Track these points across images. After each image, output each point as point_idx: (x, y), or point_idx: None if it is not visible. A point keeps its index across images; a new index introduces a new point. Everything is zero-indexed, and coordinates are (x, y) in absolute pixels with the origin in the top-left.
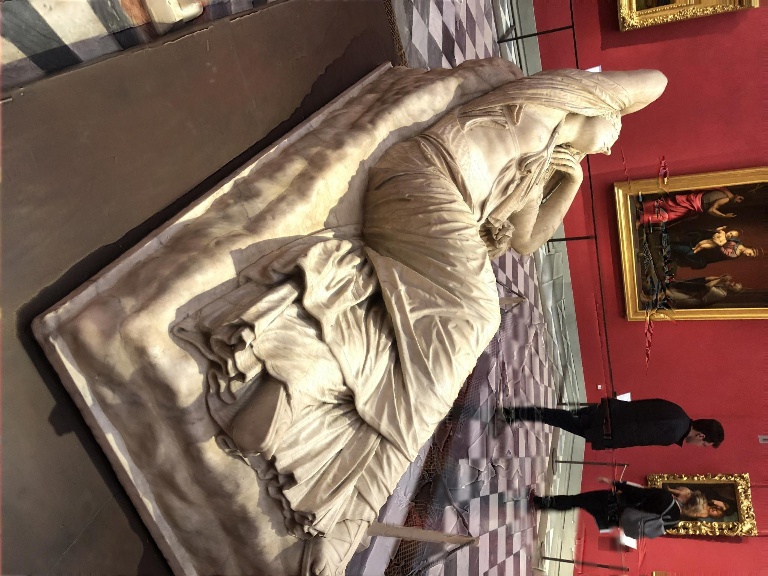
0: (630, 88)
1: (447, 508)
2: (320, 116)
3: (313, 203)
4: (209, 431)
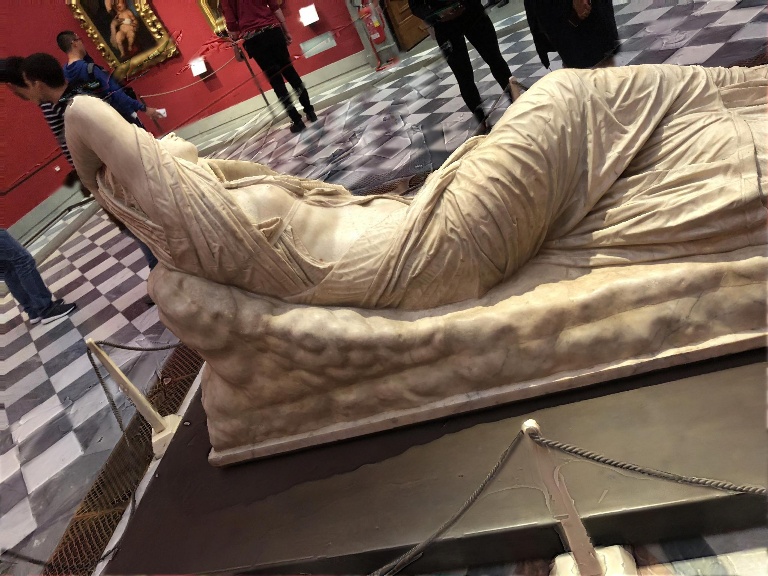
0: (128, 130)
1: (487, 125)
2: (440, 406)
3: None
4: None
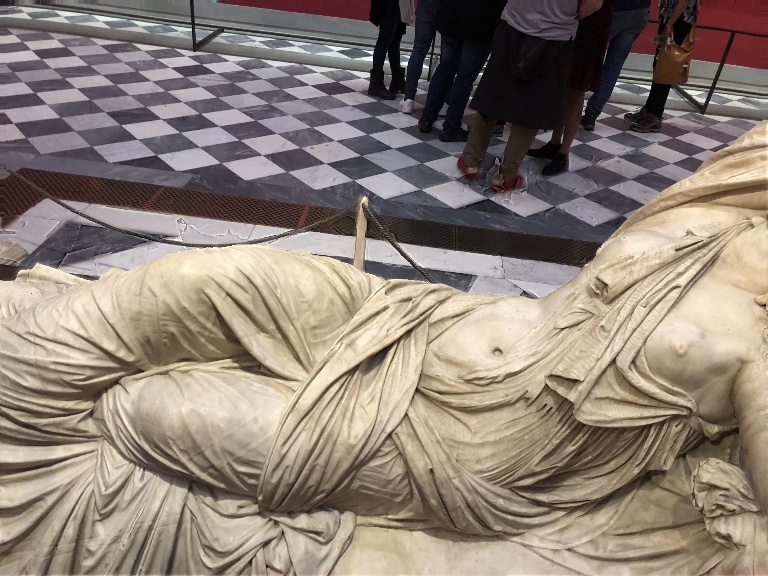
0: None
1: None
2: None
3: None
4: None
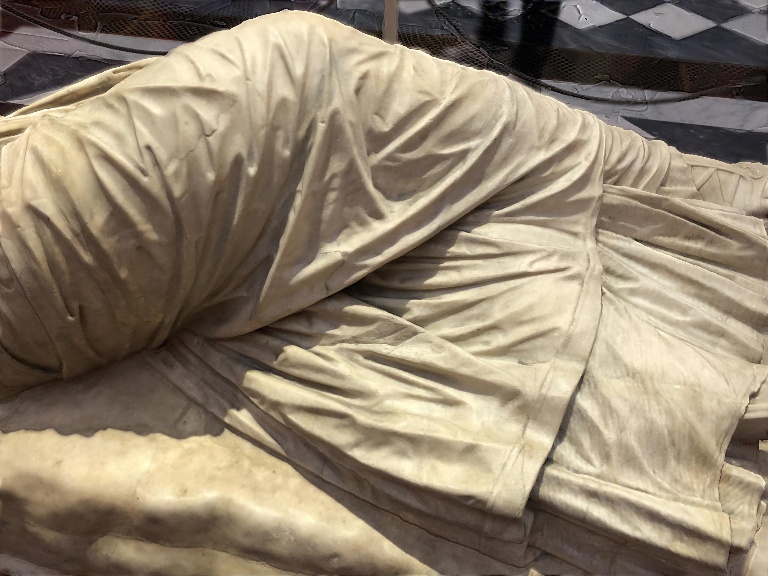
0: None
1: (340, 6)
2: None
3: (217, 490)
4: (762, 461)
